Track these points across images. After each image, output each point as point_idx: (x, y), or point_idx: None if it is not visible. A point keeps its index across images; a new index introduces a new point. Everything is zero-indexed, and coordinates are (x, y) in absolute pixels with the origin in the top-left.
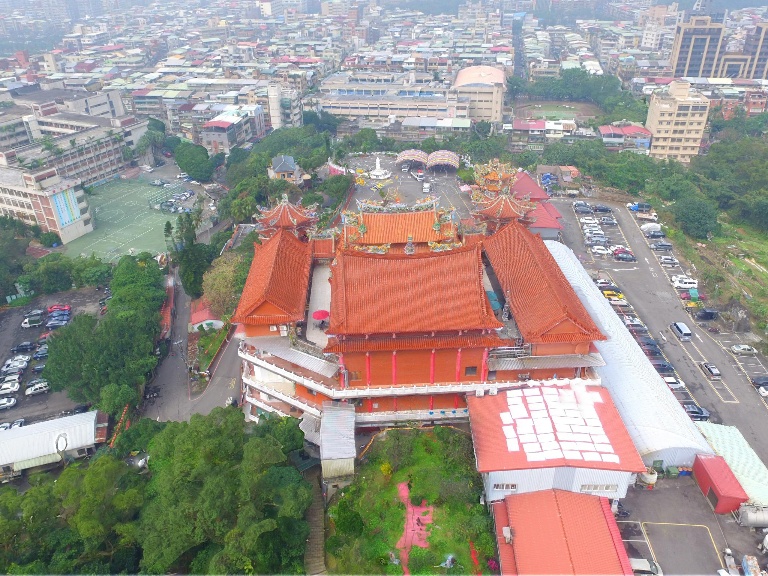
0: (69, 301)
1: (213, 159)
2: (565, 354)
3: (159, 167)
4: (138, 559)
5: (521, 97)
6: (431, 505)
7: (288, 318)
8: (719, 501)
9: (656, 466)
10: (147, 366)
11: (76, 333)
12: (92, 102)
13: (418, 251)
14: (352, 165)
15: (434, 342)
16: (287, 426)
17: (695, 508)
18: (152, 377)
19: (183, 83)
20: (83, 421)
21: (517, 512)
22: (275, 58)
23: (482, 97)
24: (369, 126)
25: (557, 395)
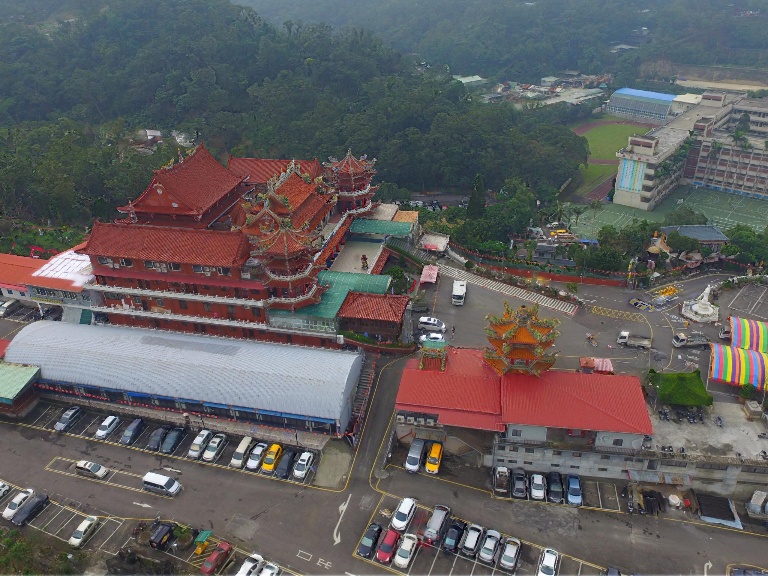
0: None
1: None
2: None
3: None
4: None
5: None
6: None
7: None
8: None
9: None
10: None
11: None
12: None
13: None
14: (744, 293)
15: None
16: None
17: None
18: None
19: None
20: None
21: None
22: None
23: None
24: None
25: None
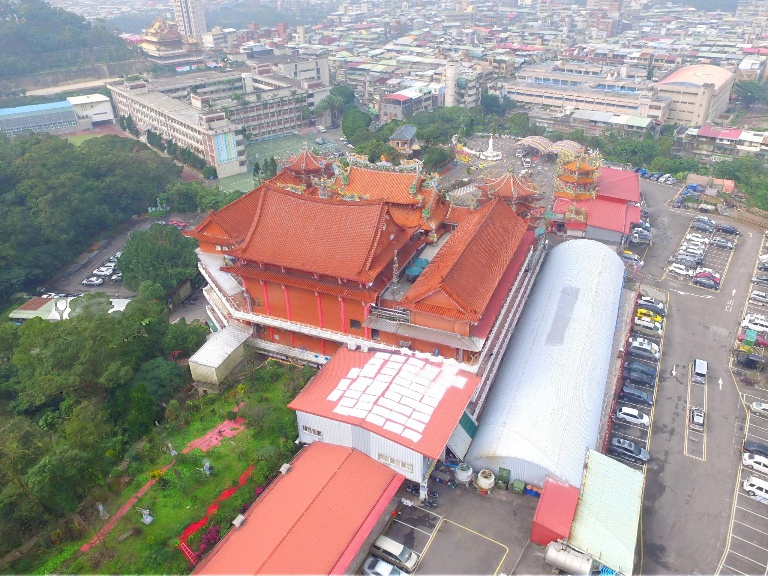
0: (189, 220)
1: (379, 128)
2: (444, 330)
3: (333, 129)
4: (60, 401)
5: (758, 106)
6: (244, 425)
7: (227, 240)
8: (532, 527)
9: (502, 474)
10: (185, 275)
11: (145, 236)
12: (301, 67)
13: (392, 211)
14: (472, 144)
15: (315, 284)
16: (184, 328)
17: (513, 528)
18: (200, 289)
19: (395, 59)
20: (122, 304)
21: (309, 456)
22: (499, 44)
23: (687, 98)
24: (539, 114)
25: (419, 368)
